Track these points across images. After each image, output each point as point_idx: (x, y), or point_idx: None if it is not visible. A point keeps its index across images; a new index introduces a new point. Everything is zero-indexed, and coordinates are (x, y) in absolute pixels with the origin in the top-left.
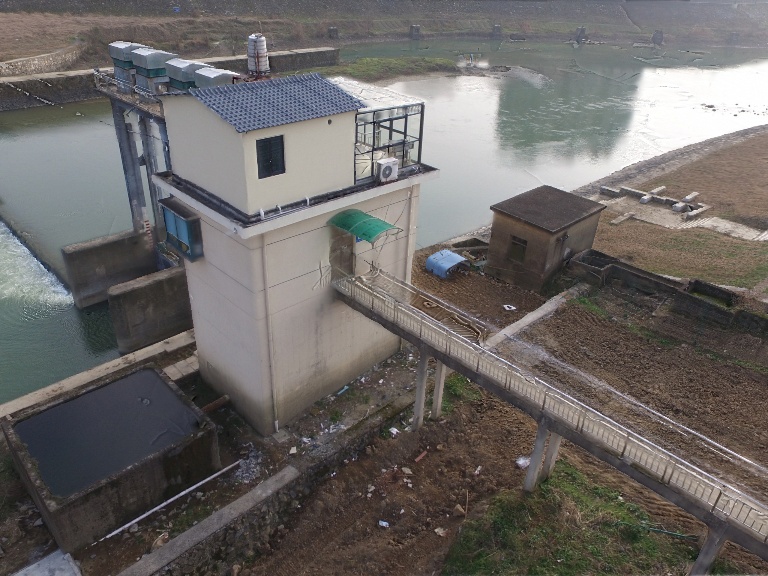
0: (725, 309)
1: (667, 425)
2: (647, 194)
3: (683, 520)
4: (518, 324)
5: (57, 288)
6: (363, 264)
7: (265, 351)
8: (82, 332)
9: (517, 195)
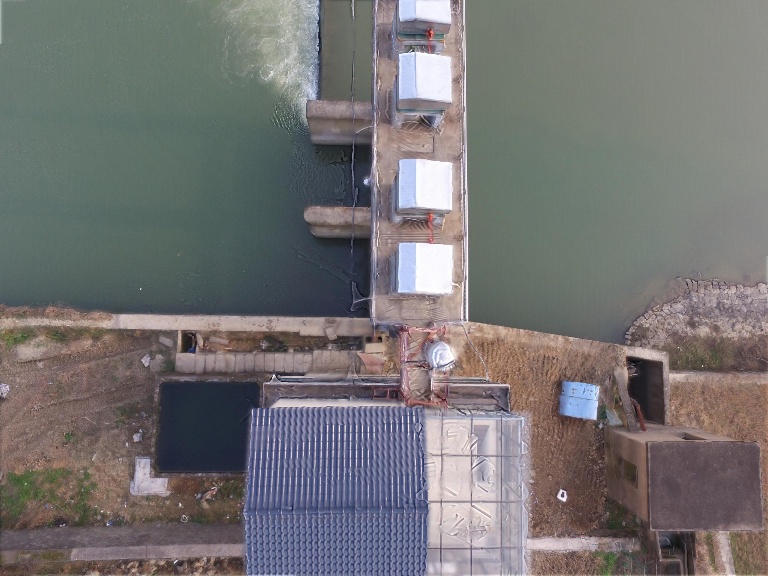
0: None
1: None
2: None
3: None
4: None
5: (312, 90)
6: None
7: None
8: (301, 175)
9: (700, 443)
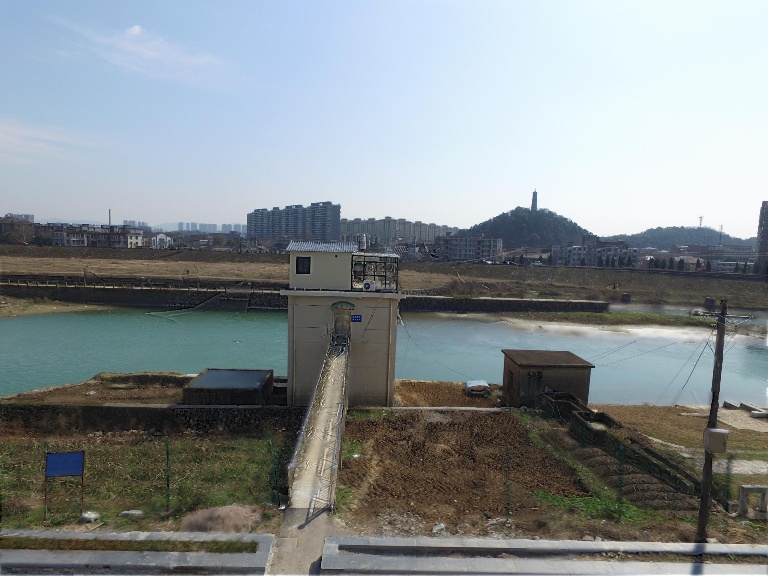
0: (590, 426)
1: (449, 457)
2: (763, 411)
3: (361, 465)
4: (454, 407)
5: None
6: (356, 336)
7: (291, 361)
8: None
9: None
